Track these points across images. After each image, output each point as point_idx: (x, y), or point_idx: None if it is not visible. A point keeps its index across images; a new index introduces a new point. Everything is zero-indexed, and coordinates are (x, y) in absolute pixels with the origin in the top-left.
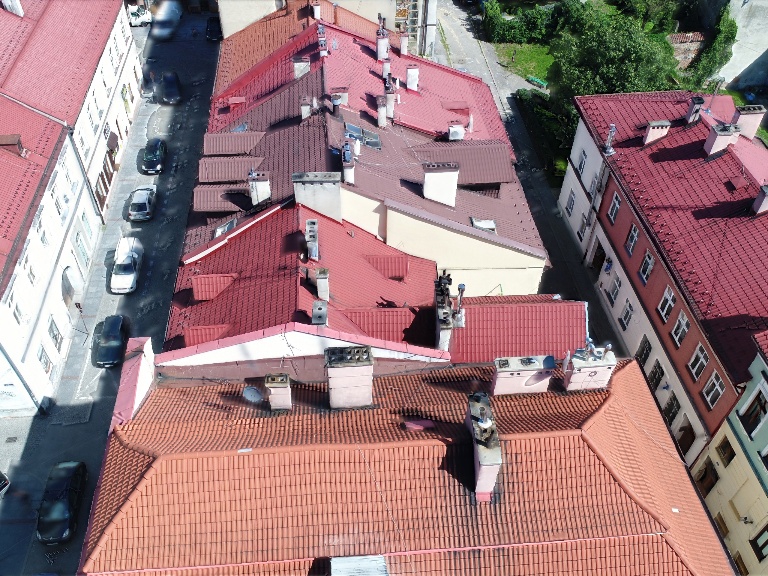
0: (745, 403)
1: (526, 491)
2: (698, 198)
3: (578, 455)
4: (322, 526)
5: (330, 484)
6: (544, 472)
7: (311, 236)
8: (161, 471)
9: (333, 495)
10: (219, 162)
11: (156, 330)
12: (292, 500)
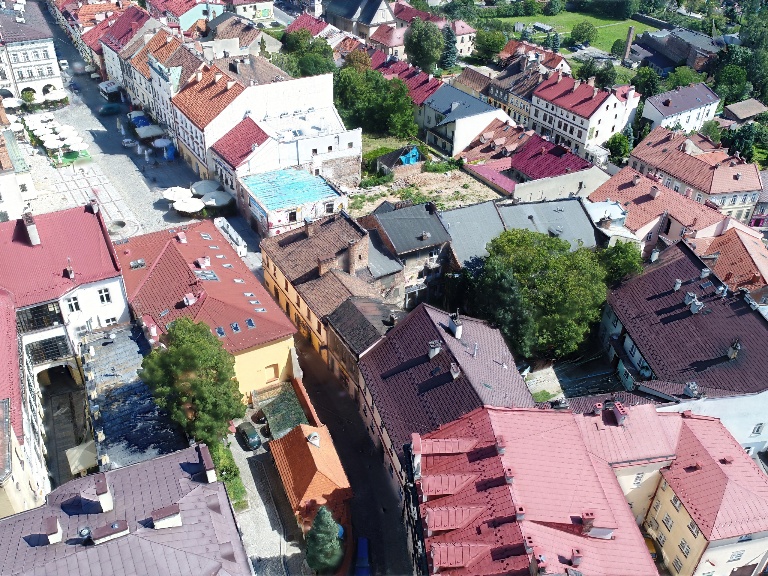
0: (168, 19)
1: (126, 7)
2: (162, 1)
3: None
4: (104, 11)
5: None
6: (128, 5)
7: (93, 3)
8: (84, 7)
9: (104, 8)
10: (70, 7)
11: (62, 46)
12: None
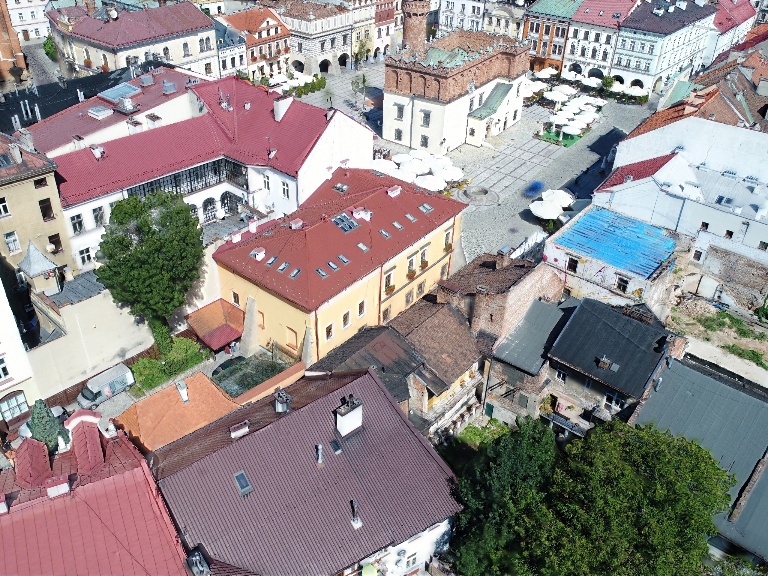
0: None
1: None
2: None
3: None
4: None
5: None
6: None
7: None
8: None
9: None
10: None
11: None
12: None
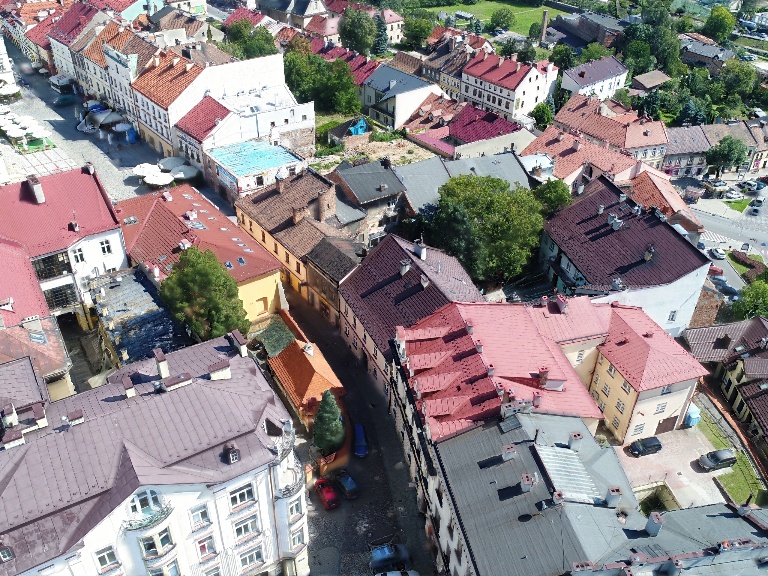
0: None
1: None
2: None
3: (72, 0)
4: None
5: (45, 5)
6: (69, 3)
7: None
8: (25, 5)
9: None
10: (8, 7)
11: None
12: (41, 7)
